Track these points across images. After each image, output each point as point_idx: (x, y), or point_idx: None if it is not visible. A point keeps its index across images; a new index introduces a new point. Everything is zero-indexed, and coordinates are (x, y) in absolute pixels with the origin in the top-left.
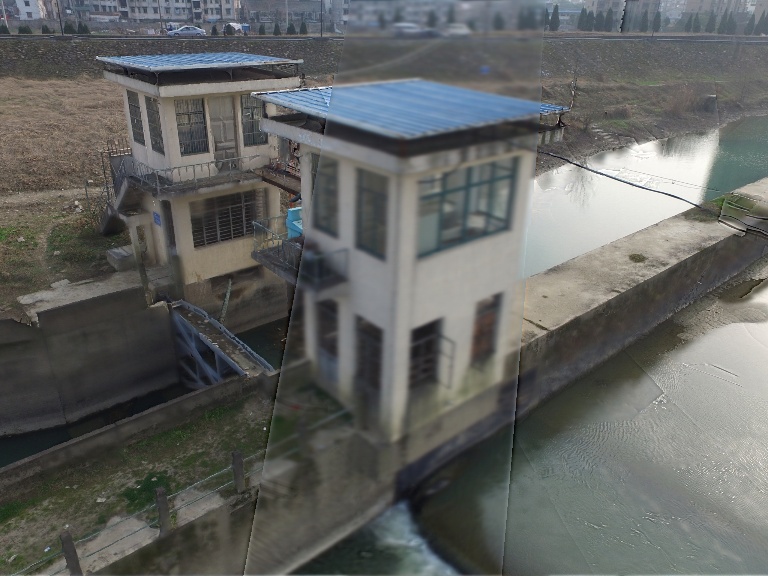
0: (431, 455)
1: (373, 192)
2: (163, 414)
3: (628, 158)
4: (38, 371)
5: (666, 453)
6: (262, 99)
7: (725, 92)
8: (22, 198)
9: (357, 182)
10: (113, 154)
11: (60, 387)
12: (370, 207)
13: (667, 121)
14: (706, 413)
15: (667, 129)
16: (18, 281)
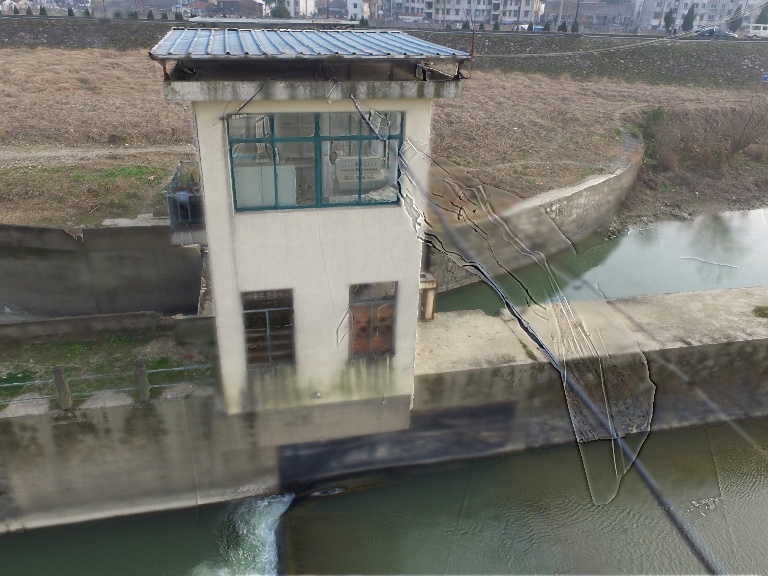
0: None
1: None
2: (70, 326)
3: None
4: (81, 280)
5: (652, 568)
6: None
7: None
8: (187, 148)
9: None
10: None
11: (98, 298)
12: None
13: None
14: (765, 543)
15: None
16: (120, 208)
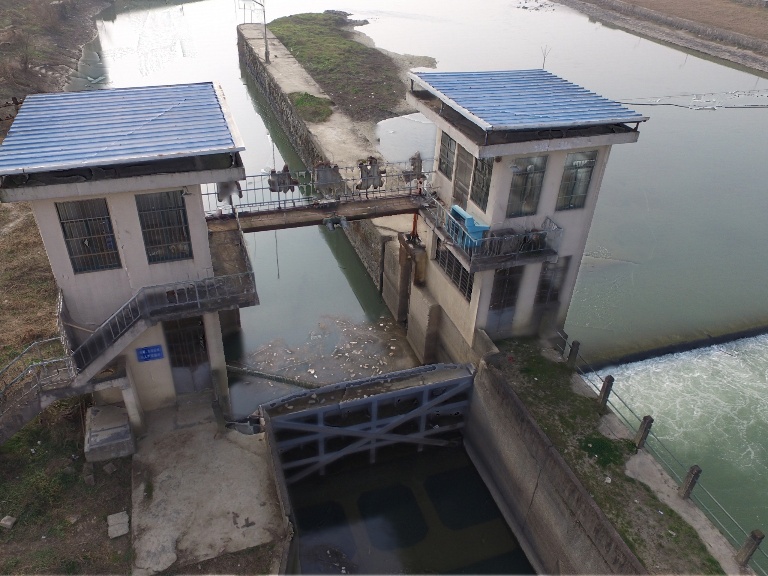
0: None
1: None
2: None
3: (95, 87)
4: None
5: None
6: (500, 129)
7: (134, 2)
8: None
9: None
10: None
11: None
12: None
13: (59, 39)
14: None
15: (69, 47)
16: None
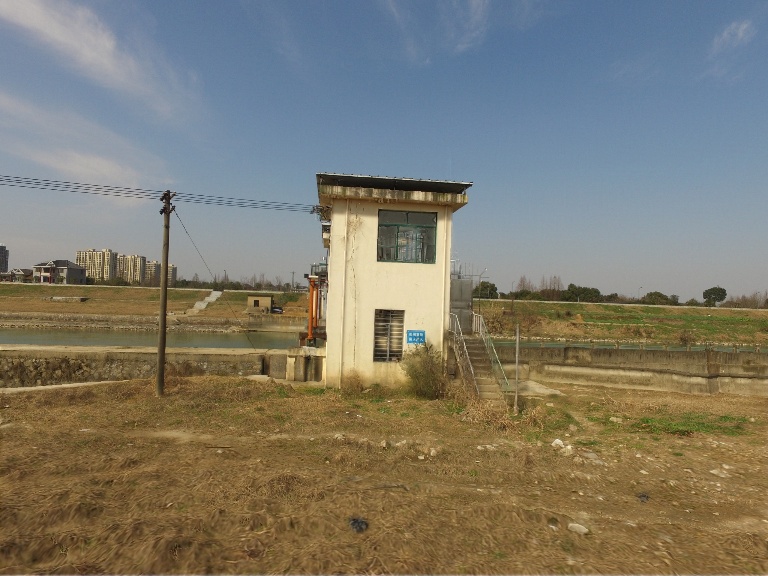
0: (452, 251)
1: (455, 236)
2: None
3: None
4: None
5: None
6: None
7: None
8: None
9: (456, 235)
10: (469, 279)
11: None
12: (455, 236)
13: None
14: None
15: None
16: None
